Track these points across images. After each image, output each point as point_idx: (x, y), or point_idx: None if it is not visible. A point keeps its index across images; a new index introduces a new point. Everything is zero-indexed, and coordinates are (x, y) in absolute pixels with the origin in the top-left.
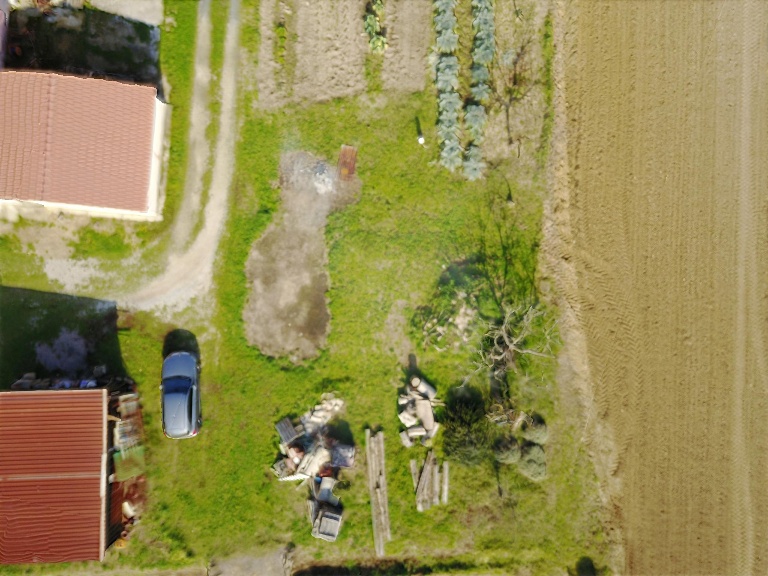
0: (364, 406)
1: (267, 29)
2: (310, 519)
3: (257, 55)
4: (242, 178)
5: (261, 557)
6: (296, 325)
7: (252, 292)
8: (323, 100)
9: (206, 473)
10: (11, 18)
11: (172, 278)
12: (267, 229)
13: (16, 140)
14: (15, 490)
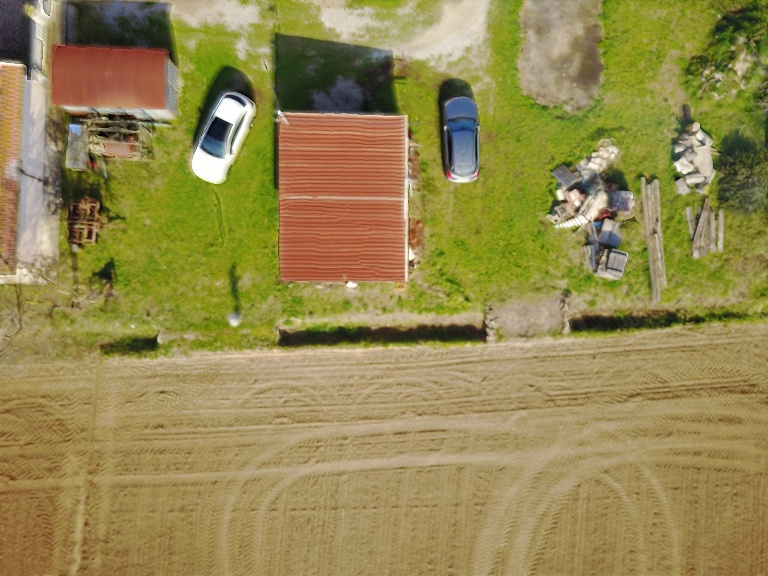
0: (638, 155)
1: None
2: (587, 264)
3: None
4: None
5: (537, 302)
6: (570, 75)
7: (526, 42)
8: None
9: (482, 220)
10: None
11: (447, 27)
12: None
13: None
14: (327, 207)
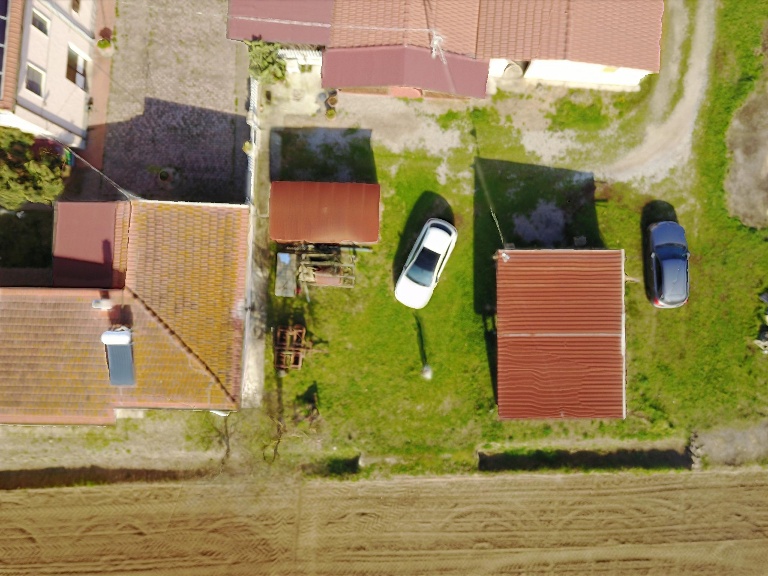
0: None
1: None
2: None
3: None
4: (722, 46)
5: (745, 430)
6: None
7: (732, 162)
8: None
9: (687, 345)
10: None
11: (650, 149)
12: (747, 98)
13: (534, 1)
14: (546, 345)
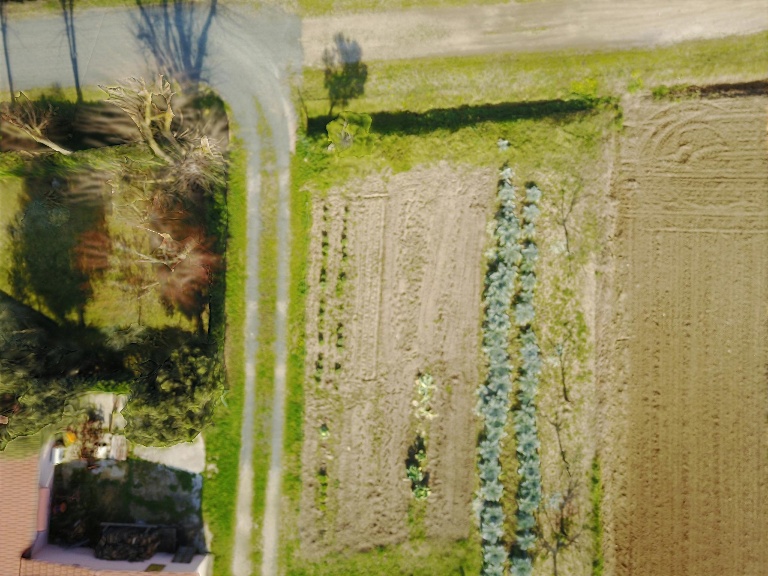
0: None
1: (308, 475)
2: None
3: (298, 503)
4: None
5: None
6: None
7: None
8: (365, 548)
9: None
10: (56, 472)
11: None
12: None
13: None
14: None
